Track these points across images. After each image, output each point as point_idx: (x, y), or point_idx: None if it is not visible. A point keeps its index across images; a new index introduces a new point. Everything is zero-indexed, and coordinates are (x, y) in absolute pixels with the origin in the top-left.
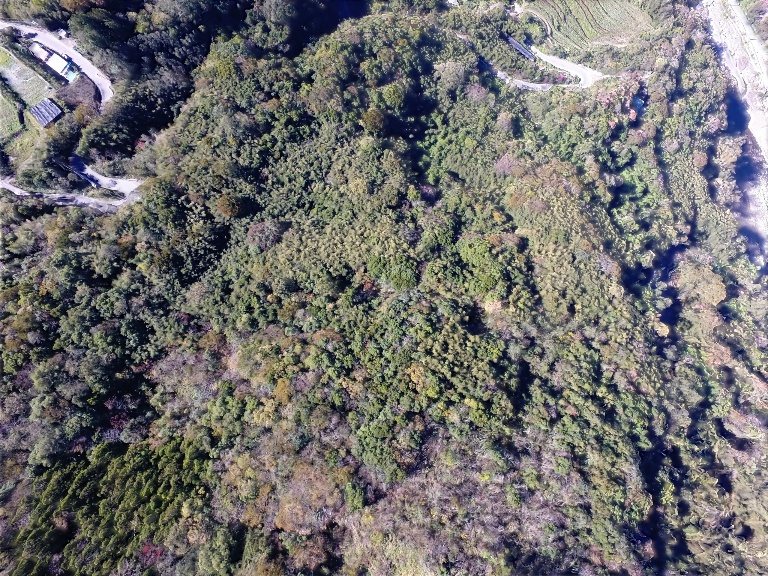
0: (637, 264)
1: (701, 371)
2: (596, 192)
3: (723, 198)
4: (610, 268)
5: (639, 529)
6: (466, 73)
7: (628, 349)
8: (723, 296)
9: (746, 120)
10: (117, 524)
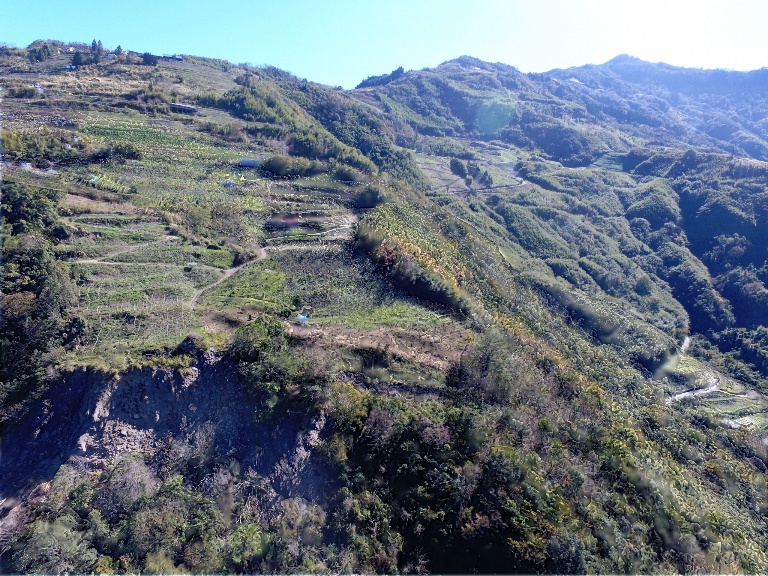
0: None
1: None
2: None
3: None
4: None
5: (494, 530)
6: None
7: None
8: None
9: None
10: None
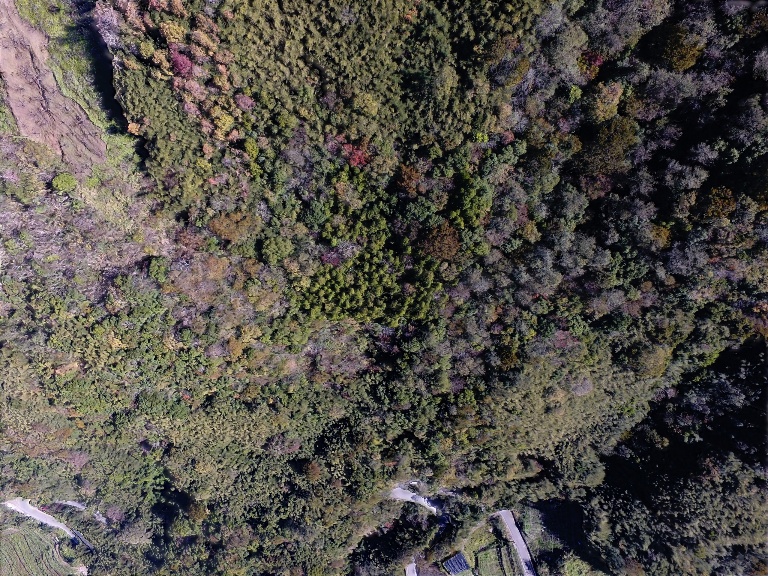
0: None
1: None
2: None
3: None
4: None
5: None
6: None
7: None
8: None
9: None
10: (363, 280)
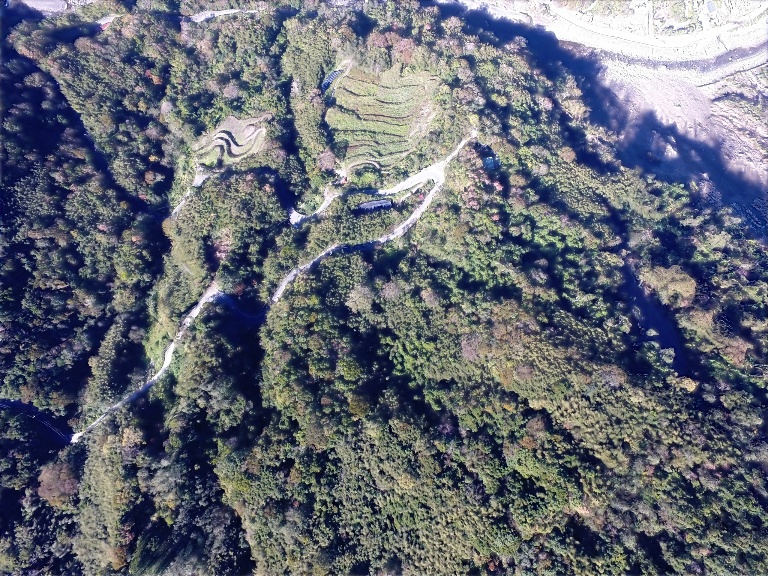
0: (623, 337)
1: (738, 377)
2: (542, 300)
3: (608, 157)
4: (615, 379)
5: None
6: (366, 278)
7: (687, 441)
8: (693, 285)
9: (552, 37)
10: None
